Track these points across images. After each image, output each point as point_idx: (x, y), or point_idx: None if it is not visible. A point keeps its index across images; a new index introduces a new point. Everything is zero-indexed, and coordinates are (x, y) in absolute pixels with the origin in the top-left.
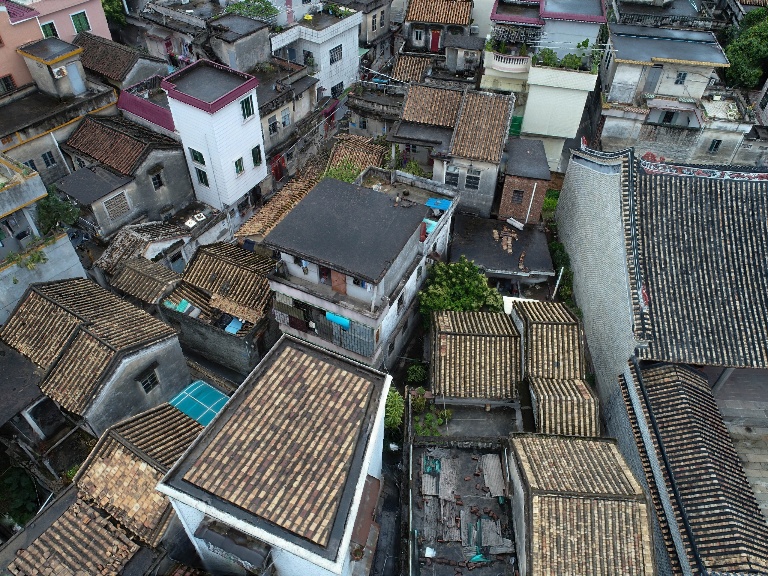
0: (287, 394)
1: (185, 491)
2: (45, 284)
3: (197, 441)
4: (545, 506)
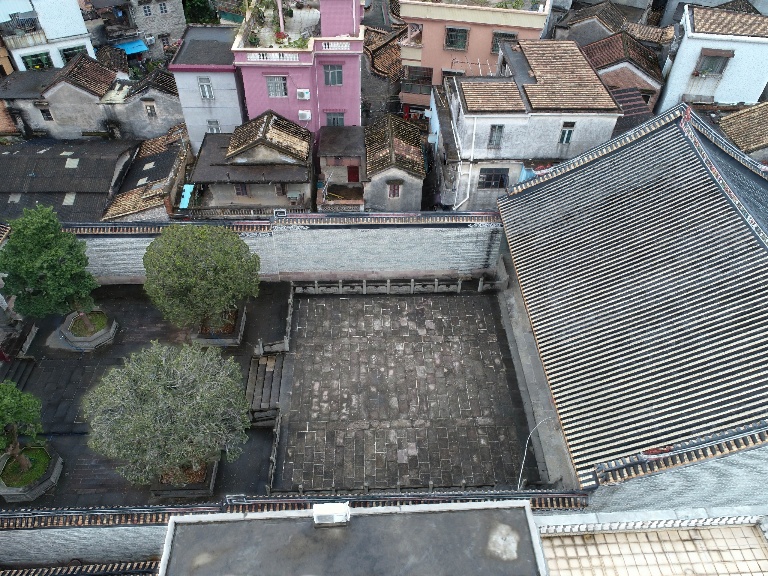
0: (752, 21)
1: (689, 10)
2: (749, 3)
3: (710, 8)
4: (766, 108)
